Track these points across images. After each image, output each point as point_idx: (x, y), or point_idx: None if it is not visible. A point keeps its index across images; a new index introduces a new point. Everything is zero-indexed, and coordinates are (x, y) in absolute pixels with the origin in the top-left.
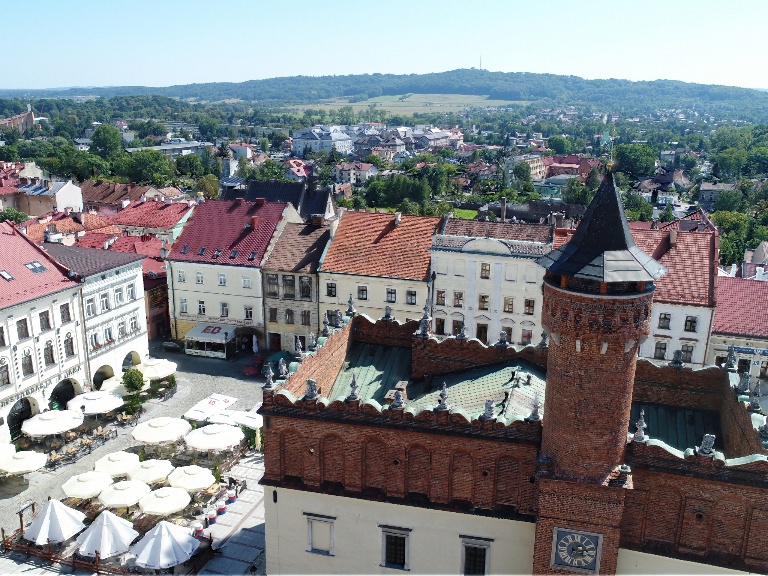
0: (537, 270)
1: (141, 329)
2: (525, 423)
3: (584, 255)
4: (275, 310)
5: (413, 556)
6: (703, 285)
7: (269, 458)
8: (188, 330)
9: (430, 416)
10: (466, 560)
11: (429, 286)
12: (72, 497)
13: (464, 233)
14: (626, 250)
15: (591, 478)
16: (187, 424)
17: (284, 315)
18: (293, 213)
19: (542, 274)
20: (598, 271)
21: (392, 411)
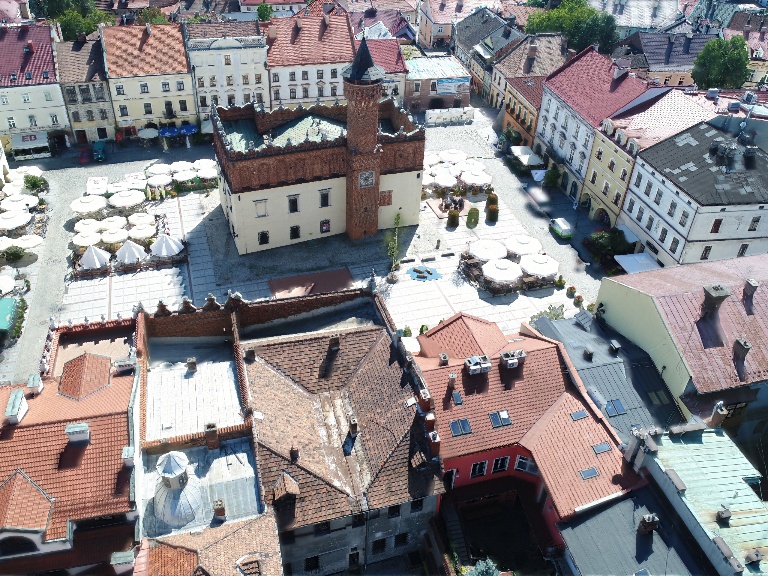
0: (260, 54)
1: (1, 148)
2: (339, 138)
3: (361, 71)
4: (77, 113)
5: (301, 205)
6: (350, 49)
7: (235, 181)
8: (4, 143)
9: (303, 145)
10: (321, 200)
11: (192, 76)
12: (79, 249)
13: (201, 34)
14: (374, 66)
15: (370, 151)
16: (102, 197)
17: (85, 115)
18: (54, 33)
19: (263, 57)
20: (368, 77)
21: (288, 147)
